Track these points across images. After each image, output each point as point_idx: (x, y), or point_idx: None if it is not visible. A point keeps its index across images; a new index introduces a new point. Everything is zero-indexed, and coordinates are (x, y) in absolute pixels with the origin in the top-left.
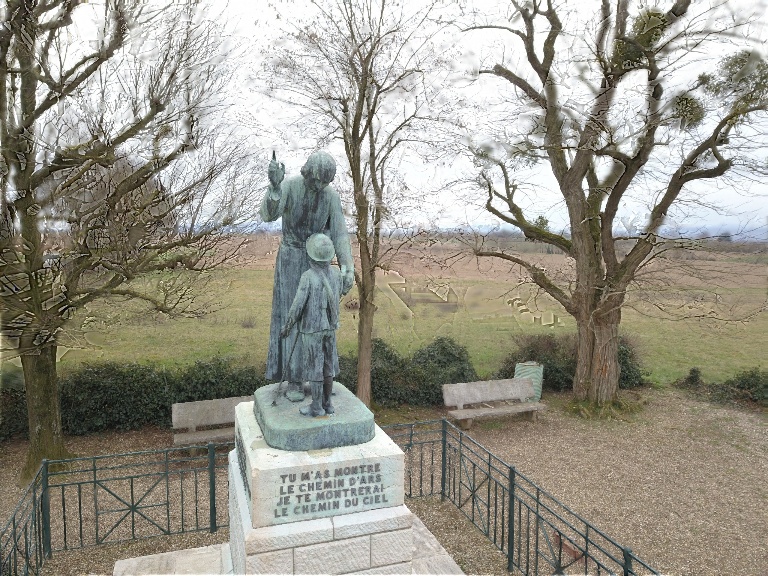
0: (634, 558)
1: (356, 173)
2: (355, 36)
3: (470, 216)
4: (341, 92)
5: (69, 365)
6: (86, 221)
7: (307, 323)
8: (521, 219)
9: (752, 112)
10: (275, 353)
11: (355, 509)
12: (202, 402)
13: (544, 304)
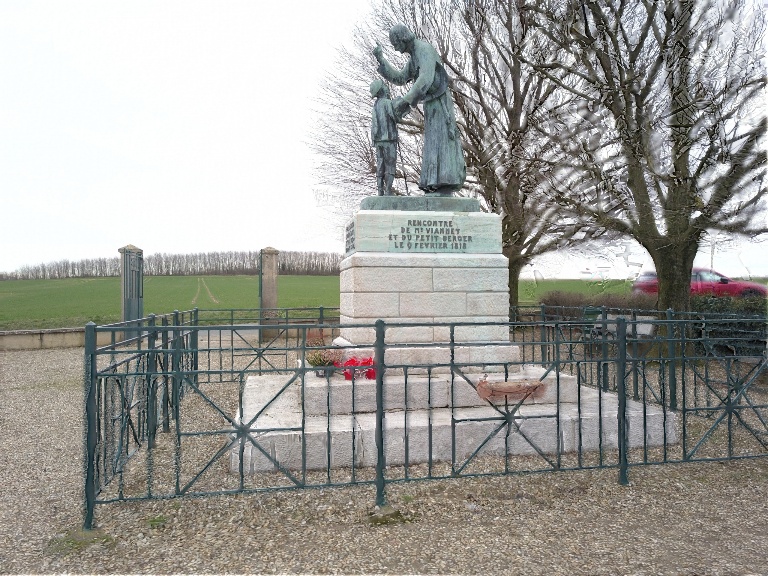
0: None
1: None
2: None
3: None
4: None
5: (761, 295)
6: None
7: None
8: None
9: None
10: None
11: None
12: None
13: None
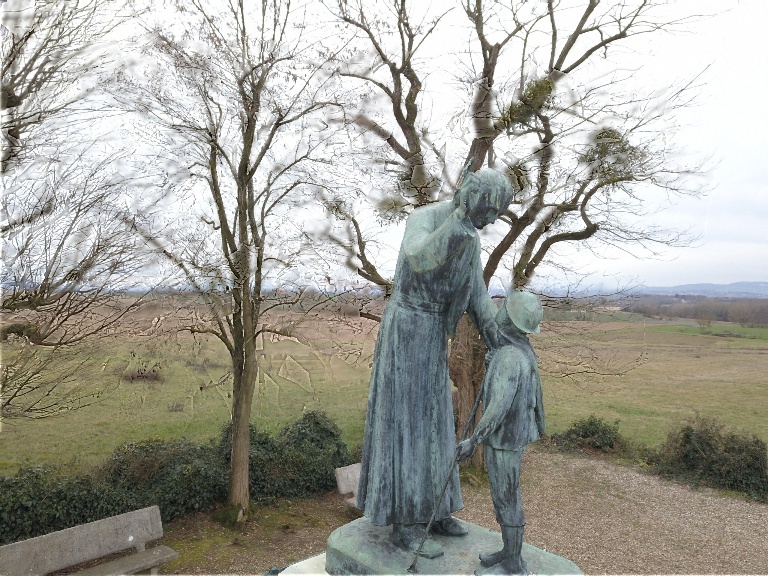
0: None
1: (242, 218)
2: (246, 56)
3: None
4: None
5: None
6: None
7: (518, 434)
8: (378, 277)
9: (619, 182)
10: (389, 481)
11: None
12: (25, 542)
13: None
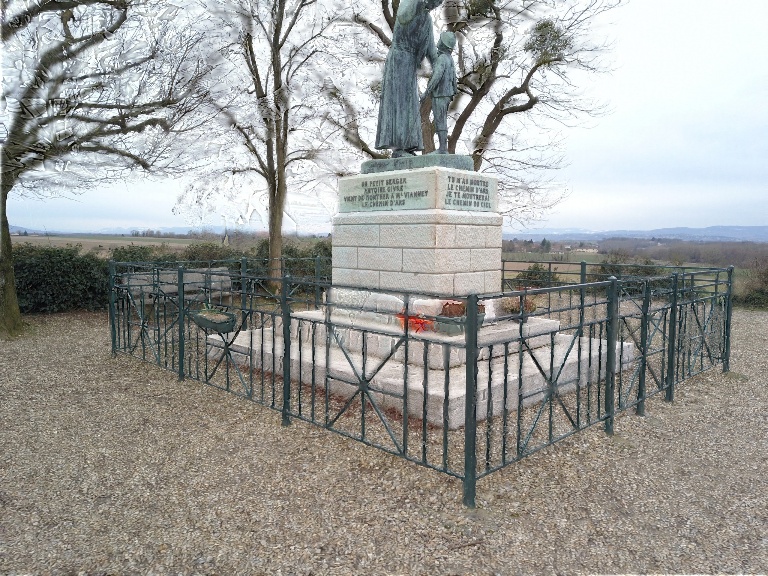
0: None
1: (276, 76)
2: None
3: None
4: None
5: None
6: (102, 58)
7: (444, 88)
8: None
9: (553, 62)
10: (390, 127)
11: (478, 209)
12: None
13: None
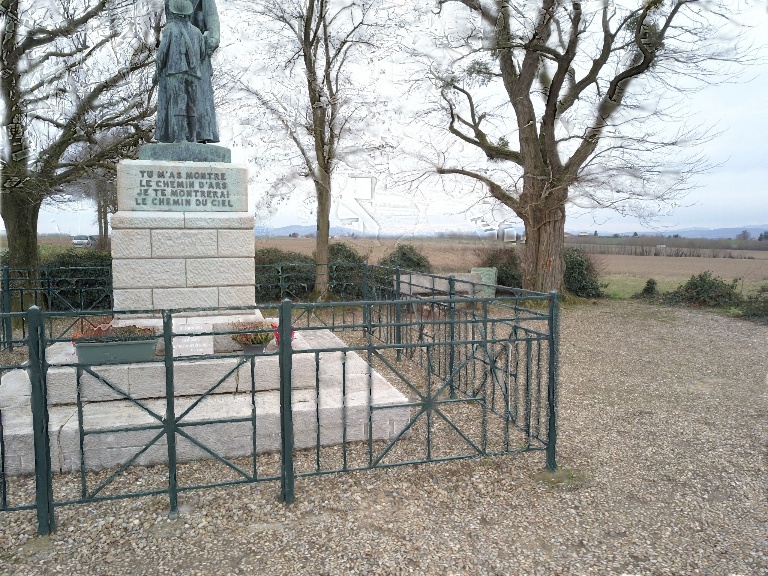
0: (454, 279)
1: None
2: None
3: (435, 139)
4: (300, 8)
5: (55, 251)
6: (49, 83)
7: (169, 64)
8: (484, 142)
9: (667, 0)
10: (162, 118)
11: (205, 208)
12: None
13: (500, 214)
